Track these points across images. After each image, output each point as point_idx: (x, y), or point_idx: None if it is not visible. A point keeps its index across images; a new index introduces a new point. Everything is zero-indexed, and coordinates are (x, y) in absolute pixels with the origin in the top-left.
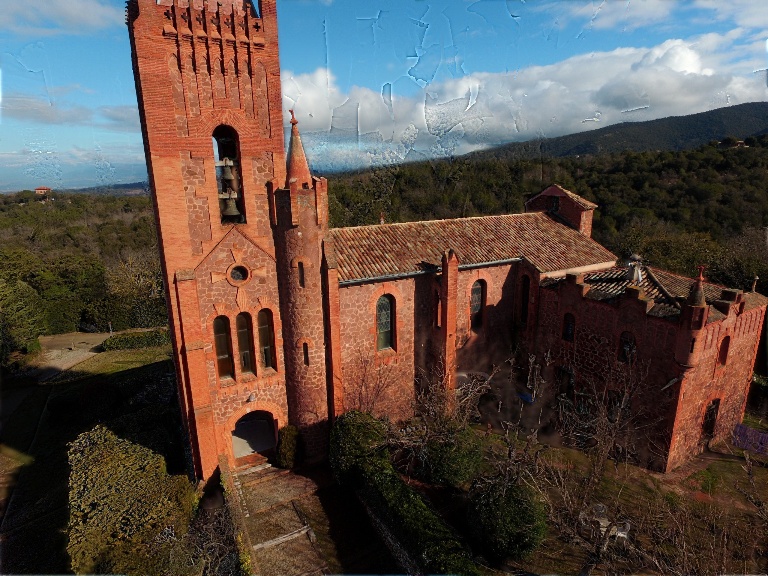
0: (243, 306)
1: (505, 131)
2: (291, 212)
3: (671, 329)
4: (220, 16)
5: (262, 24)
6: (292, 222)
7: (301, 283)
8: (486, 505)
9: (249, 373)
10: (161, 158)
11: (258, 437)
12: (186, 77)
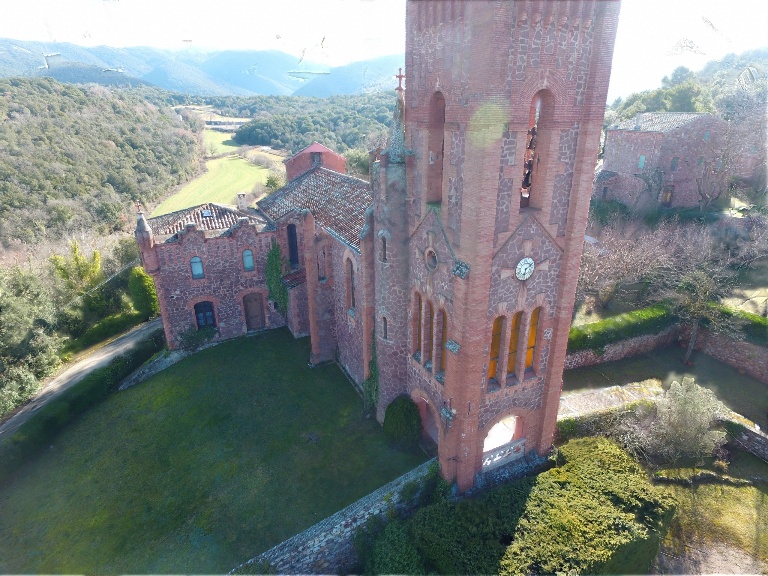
0: None
1: None
2: None
3: None
4: None
5: None
6: None
7: None
8: None
9: None
10: None
11: None
12: None
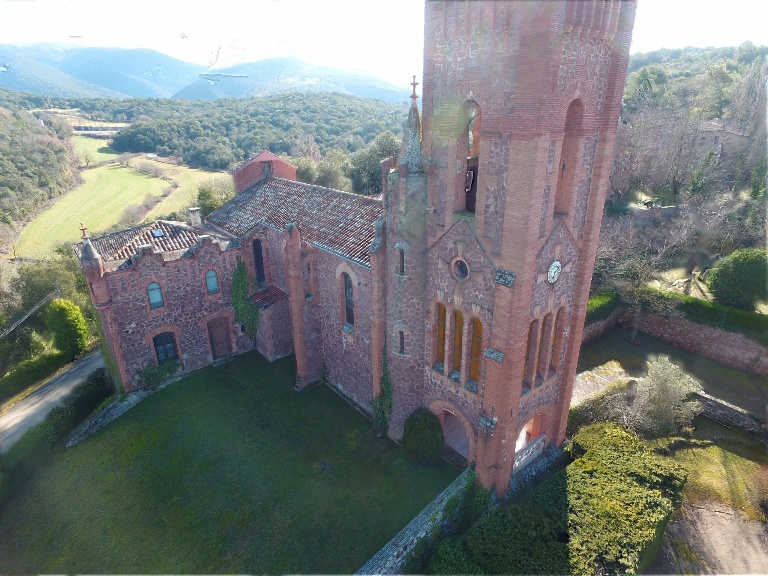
0: None
1: None
2: None
3: None
4: None
5: None
6: None
7: None
8: None
9: None
10: None
11: None
12: None
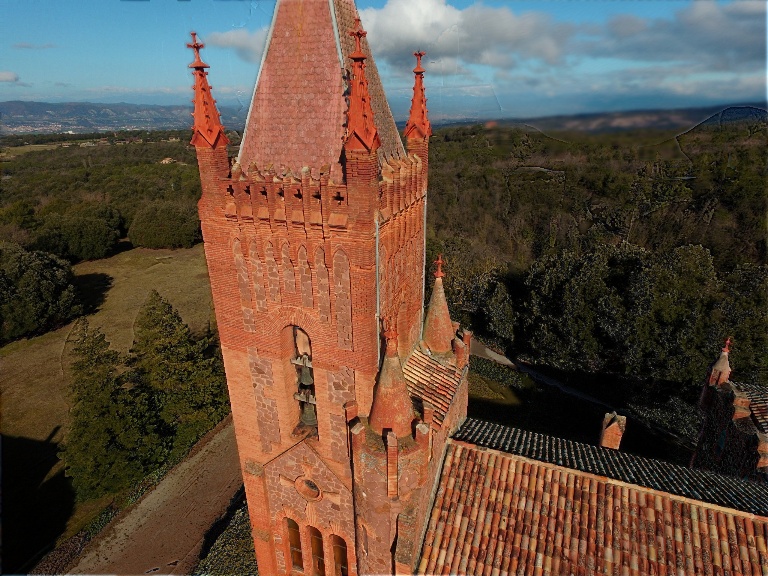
0: (312, 521)
1: None
2: None
3: None
4: (285, 190)
5: (346, 194)
6: (354, 477)
7: (365, 547)
8: None
9: None
10: (230, 350)
11: None
12: (252, 265)
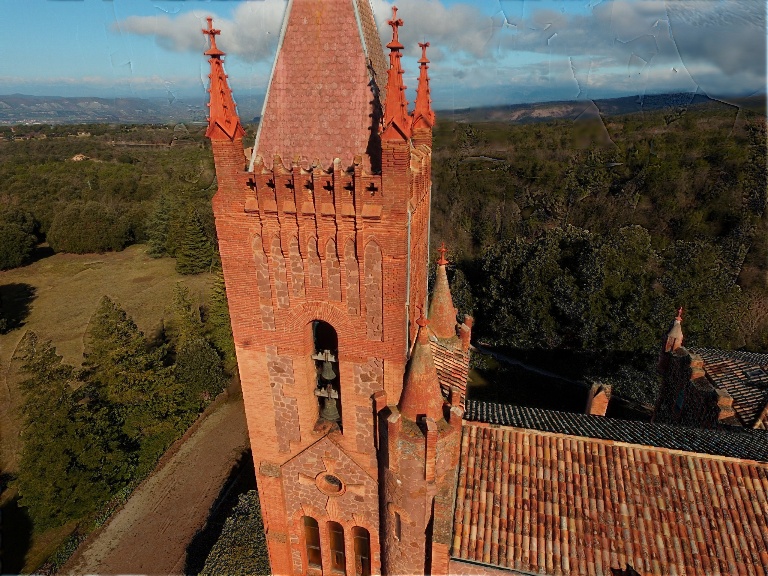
0: (334, 516)
1: None
2: (389, 454)
3: None
4: (314, 182)
5: (381, 184)
6: (389, 466)
7: (397, 533)
8: None
9: (341, 573)
10: (245, 350)
11: None
12: (273, 261)
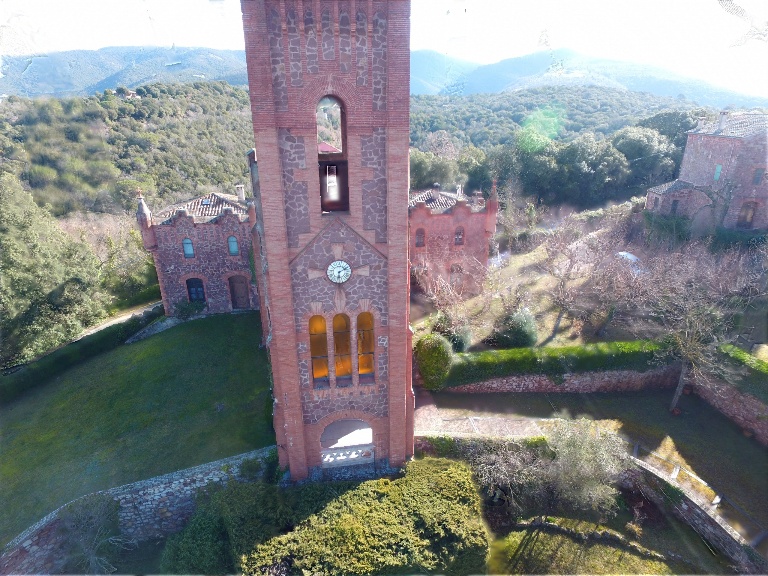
0: None
1: (58, 76)
2: None
3: (483, 217)
4: None
5: None
6: None
7: None
8: (525, 325)
9: None
10: None
11: (357, 421)
12: None
